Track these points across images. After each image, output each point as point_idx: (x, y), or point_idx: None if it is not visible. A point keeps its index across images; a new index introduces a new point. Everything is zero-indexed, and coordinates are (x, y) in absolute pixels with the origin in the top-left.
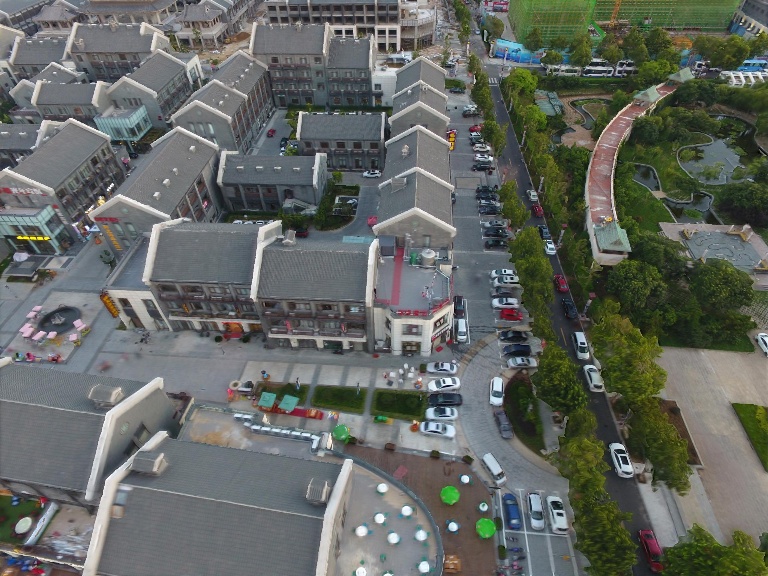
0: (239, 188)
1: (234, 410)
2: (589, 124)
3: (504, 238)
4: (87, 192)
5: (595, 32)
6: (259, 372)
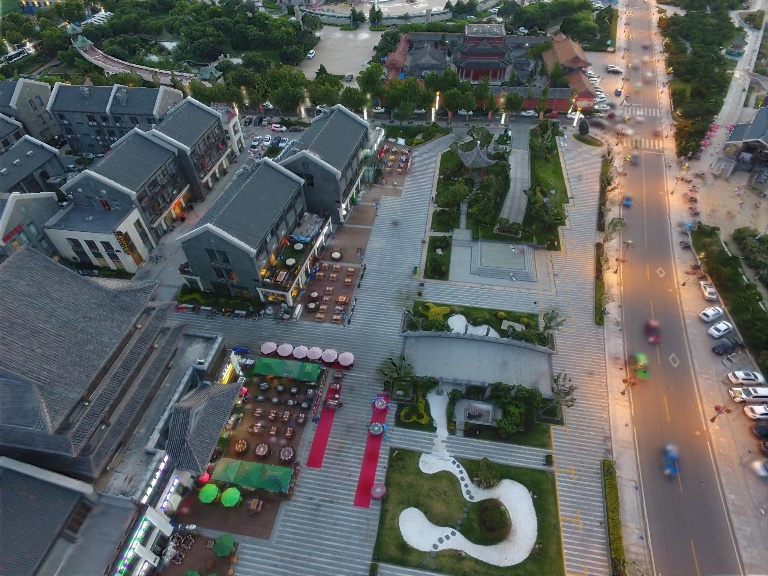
0: None
1: None
2: None
3: None
4: None
5: None
6: None
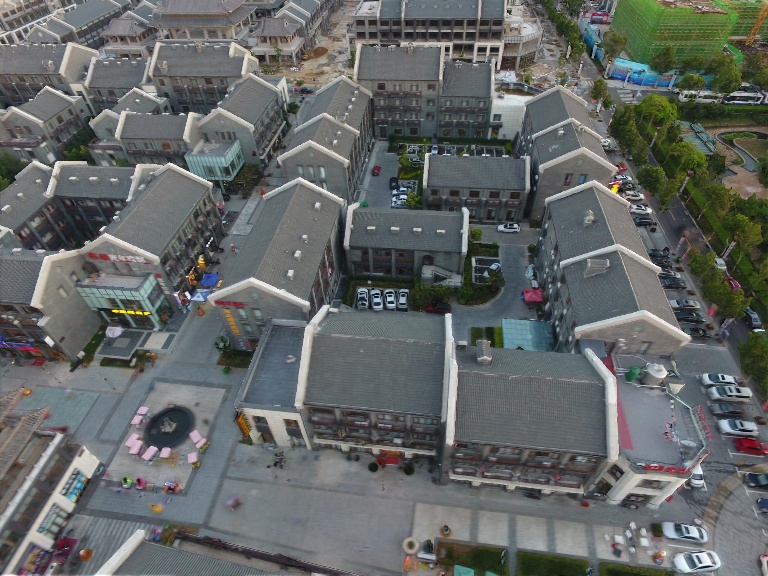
0: (368, 252)
1: None
2: (749, 164)
3: (700, 324)
4: (188, 252)
5: (727, 50)
6: (435, 522)
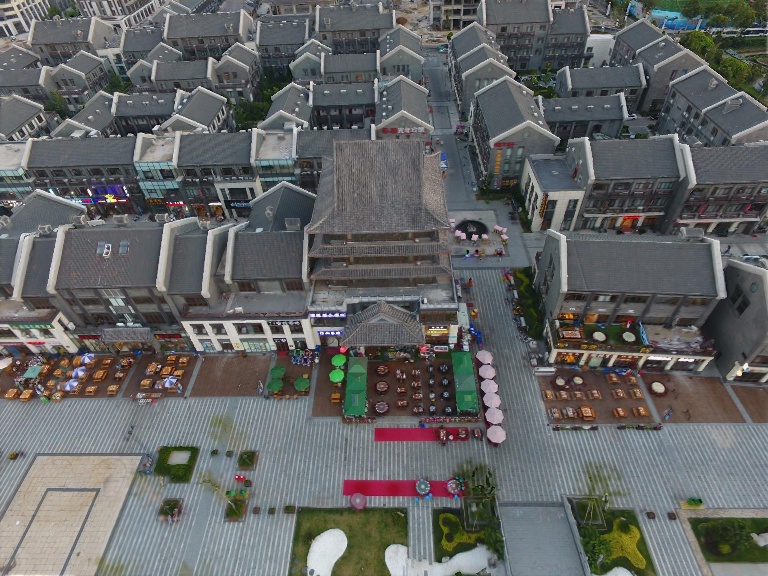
0: (556, 126)
1: (735, 256)
2: None
3: None
4: None
5: None
6: None
